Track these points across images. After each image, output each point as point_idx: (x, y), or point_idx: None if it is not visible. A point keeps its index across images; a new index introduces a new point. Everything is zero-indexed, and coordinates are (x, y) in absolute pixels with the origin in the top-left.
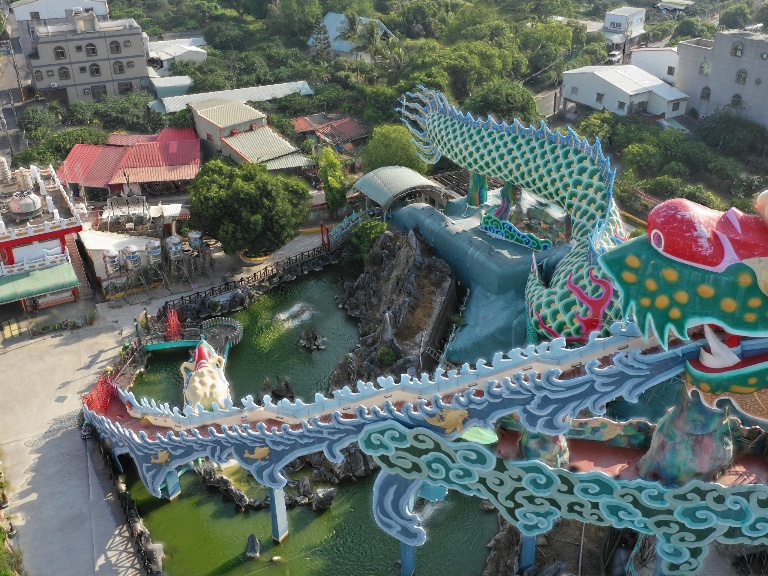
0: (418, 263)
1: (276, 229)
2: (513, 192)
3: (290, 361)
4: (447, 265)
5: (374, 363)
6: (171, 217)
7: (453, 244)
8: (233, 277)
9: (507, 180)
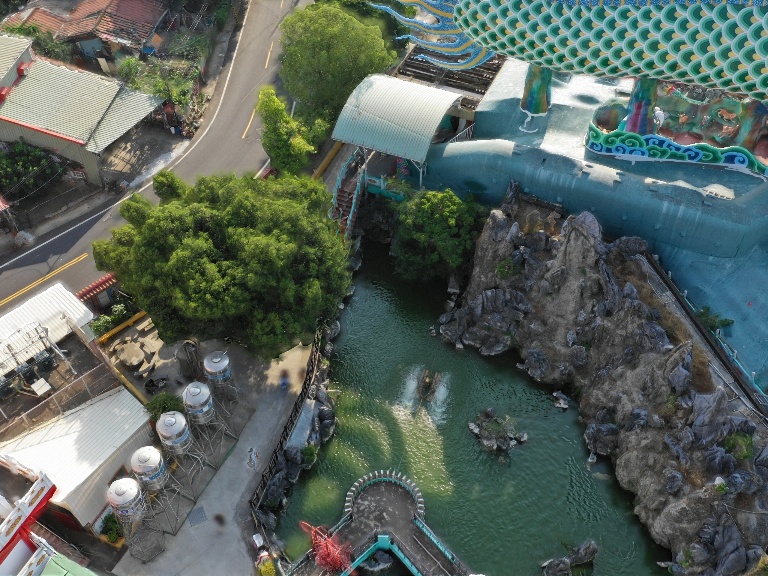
0: (604, 255)
1: (335, 284)
2: (655, 90)
3: (508, 488)
4: (644, 242)
5: (732, 466)
6: (86, 326)
7: (620, 202)
8: (267, 378)
9: (655, 77)
